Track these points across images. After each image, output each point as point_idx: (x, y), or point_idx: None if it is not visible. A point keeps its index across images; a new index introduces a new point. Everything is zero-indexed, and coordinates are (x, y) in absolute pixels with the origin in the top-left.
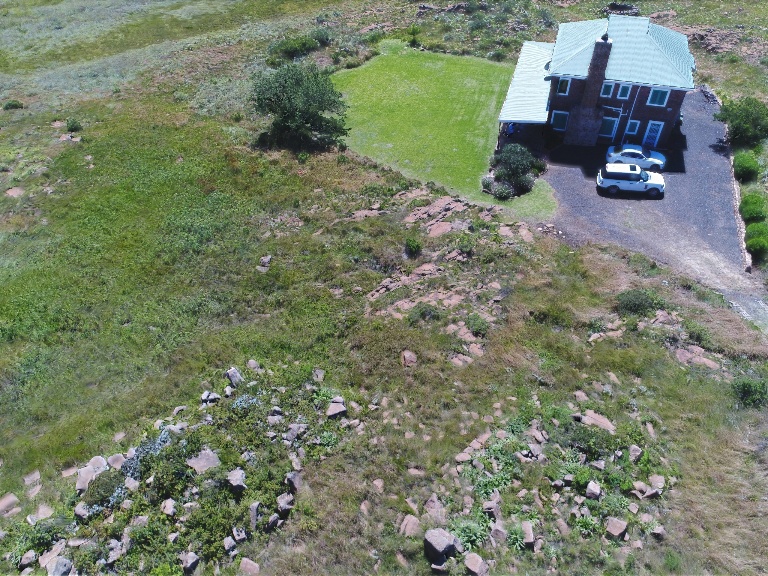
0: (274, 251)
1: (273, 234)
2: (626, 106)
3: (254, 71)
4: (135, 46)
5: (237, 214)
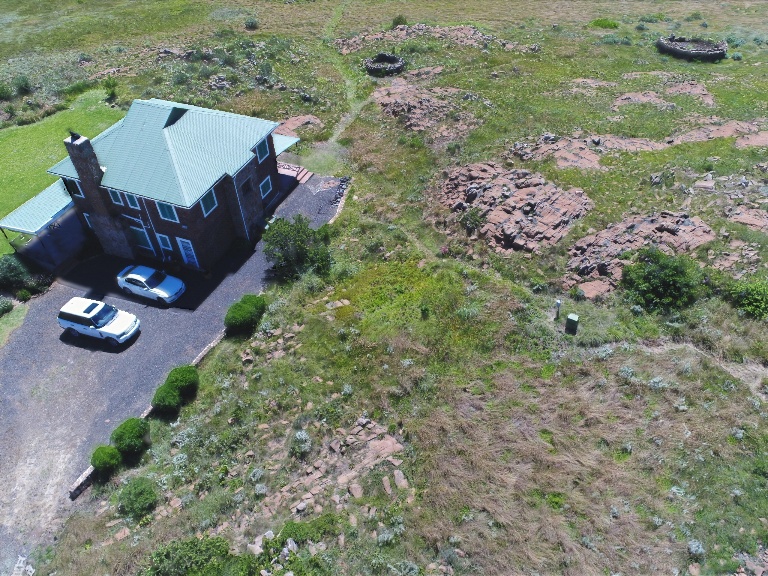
0: None
1: None
2: (144, 217)
3: None
4: None
5: None
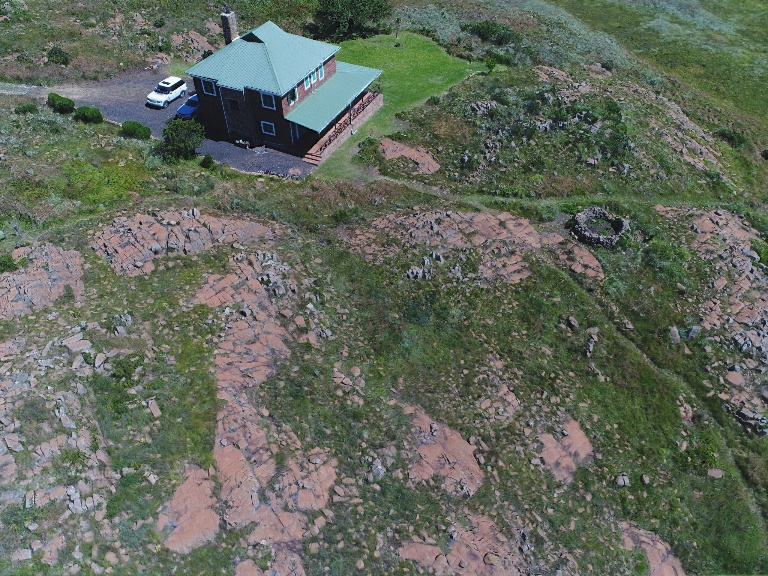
0: (190, 1)
1: (212, 6)
2: None
3: (457, 23)
4: (573, 10)
5: (244, 5)
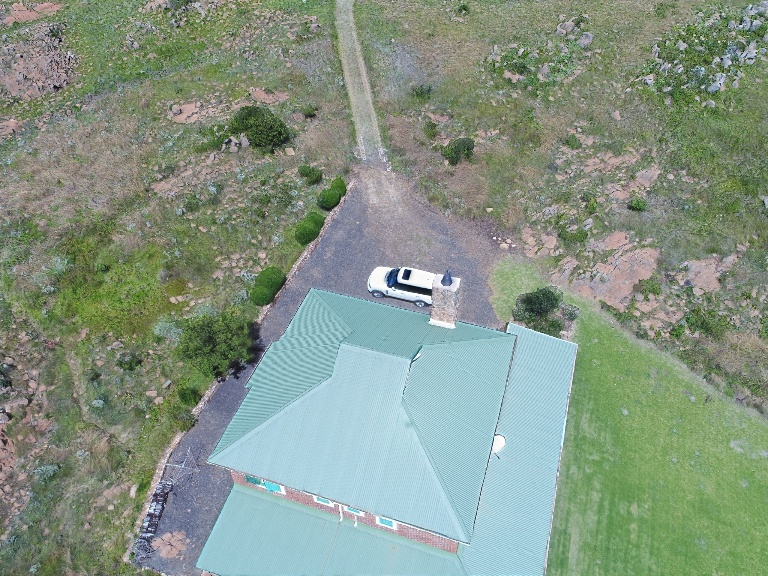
0: (767, 213)
1: None
2: None
3: None
4: None
5: None
